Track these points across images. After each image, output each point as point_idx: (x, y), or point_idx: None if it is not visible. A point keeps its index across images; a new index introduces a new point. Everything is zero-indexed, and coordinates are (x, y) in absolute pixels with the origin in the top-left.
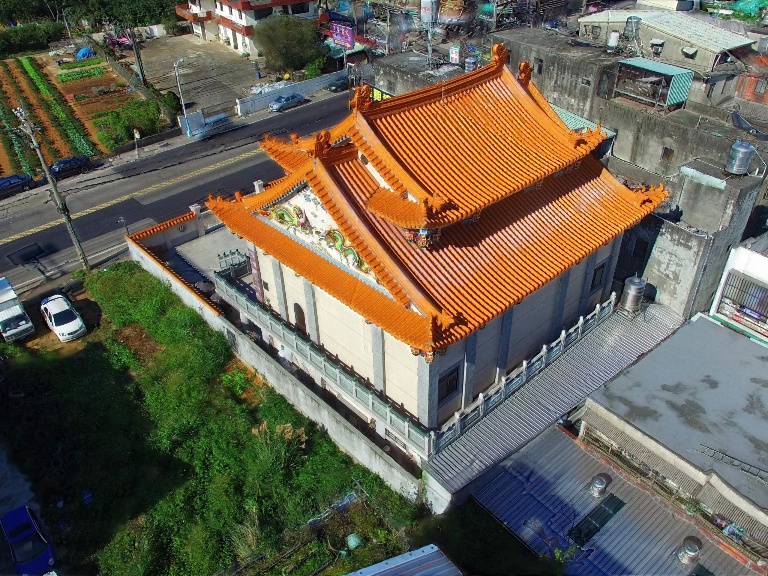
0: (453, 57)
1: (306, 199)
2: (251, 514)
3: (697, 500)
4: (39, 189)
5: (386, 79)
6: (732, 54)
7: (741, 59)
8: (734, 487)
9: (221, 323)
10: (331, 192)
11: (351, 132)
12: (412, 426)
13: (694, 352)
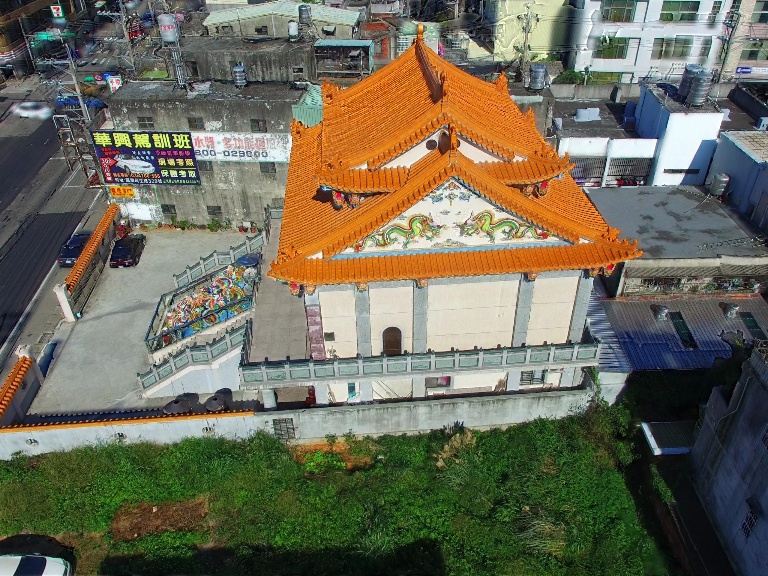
0: (115, 87)
1: (435, 200)
2: (525, 515)
3: (697, 286)
4: None
5: (135, 117)
6: (386, 21)
7: (393, 24)
8: (735, 255)
9: (261, 420)
10: (478, 177)
11: (449, 120)
12: (582, 345)
13: (617, 208)
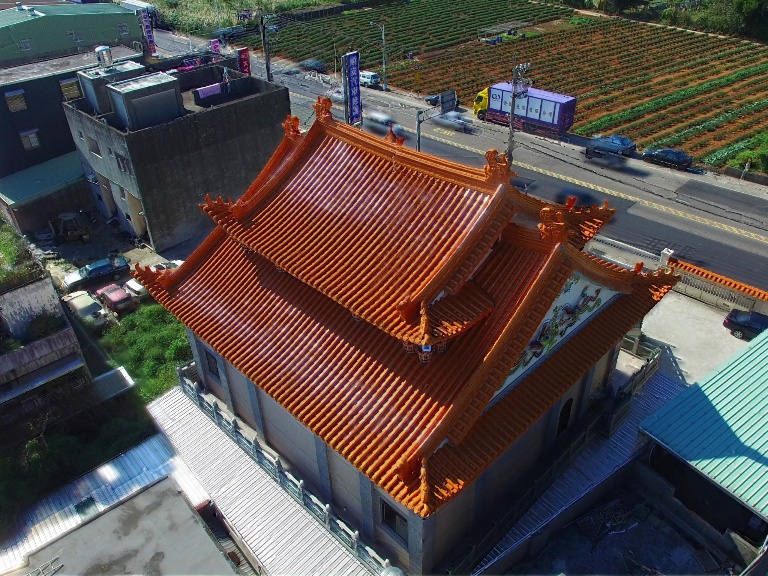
0: None
1: None
2: None
3: None
4: (626, 158)
5: None
6: None
7: None
8: None
9: None
10: None
11: None
12: None
13: None
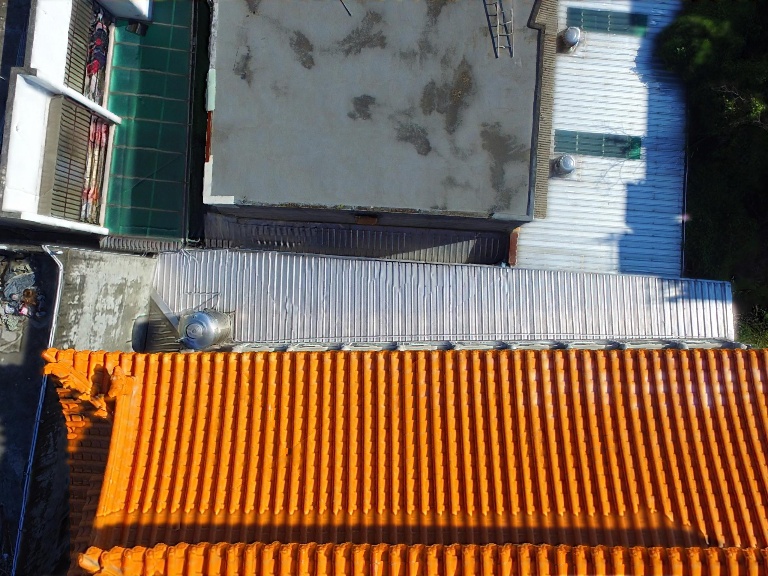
0: None
1: None
2: None
3: None
4: None
5: None
6: None
7: None
8: None
9: None
10: None
11: None
12: None
13: (313, 159)
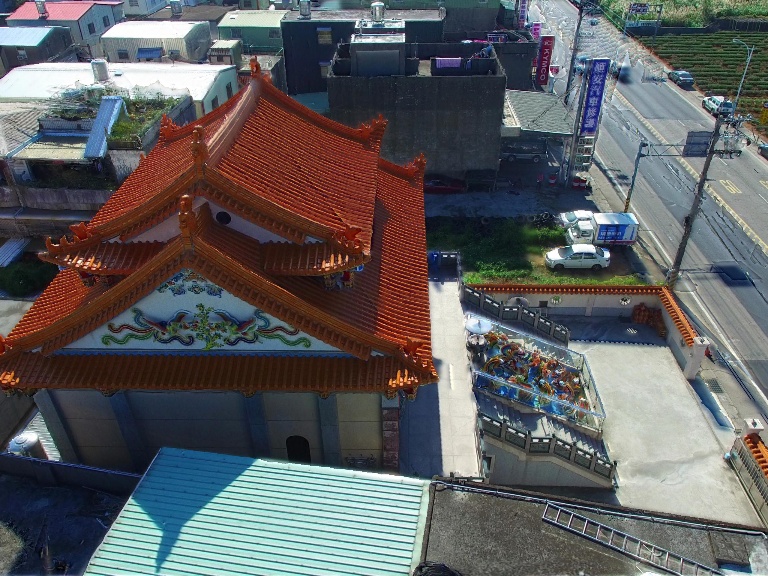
0: None
1: None
2: None
3: None
4: None
5: None
6: None
7: None
8: None
9: None
10: None
11: None
12: None
13: None
